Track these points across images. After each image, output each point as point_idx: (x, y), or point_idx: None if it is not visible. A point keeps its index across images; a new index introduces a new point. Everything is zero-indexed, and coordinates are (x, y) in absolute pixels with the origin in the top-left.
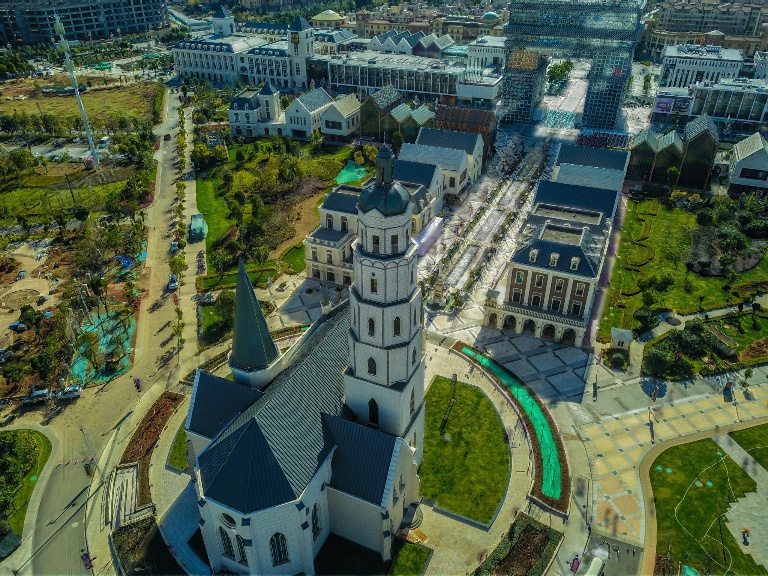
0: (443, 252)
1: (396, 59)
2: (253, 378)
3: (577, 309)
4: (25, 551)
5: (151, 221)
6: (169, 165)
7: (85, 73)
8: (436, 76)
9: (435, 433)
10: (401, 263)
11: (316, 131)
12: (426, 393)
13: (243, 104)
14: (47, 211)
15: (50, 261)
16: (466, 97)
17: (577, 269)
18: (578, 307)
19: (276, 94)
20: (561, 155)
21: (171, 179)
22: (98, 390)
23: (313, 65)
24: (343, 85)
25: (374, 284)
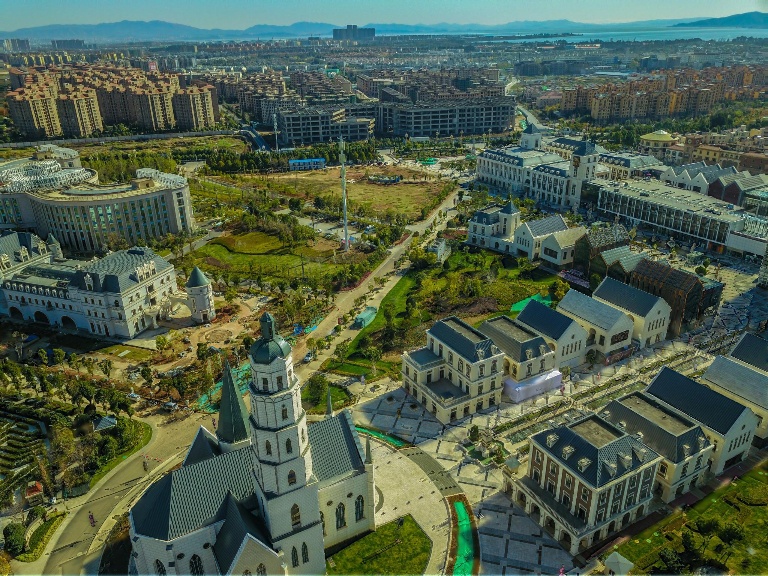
0: (539, 406)
1: (676, 195)
2: (223, 447)
3: (583, 514)
4: (85, 499)
5: (342, 303)
6: (396, 259)
7: (409, 167)
8: (706, 220)
9: (357, 559)
10: (268, 400)
11: (539, 254)
12: (385, 524)
13: (482, 218)
14: (284, 276)
15: (257, 314)
16: (736, 249)
17: (583, 472)
18: (584, 513)
19: (515, 214)
20: (741, 345)
21: (387, 271)
22: (202, 417)
23: (588, 188)
24: (610, 212)
25: (254, 409)
